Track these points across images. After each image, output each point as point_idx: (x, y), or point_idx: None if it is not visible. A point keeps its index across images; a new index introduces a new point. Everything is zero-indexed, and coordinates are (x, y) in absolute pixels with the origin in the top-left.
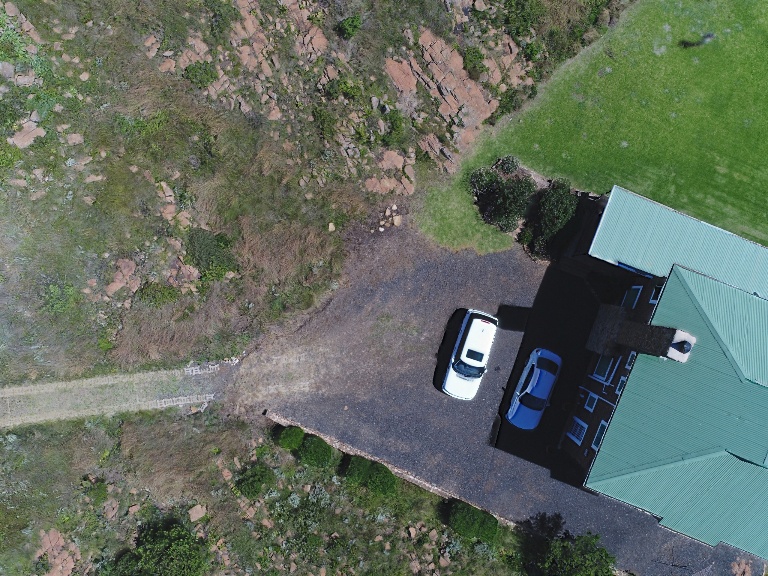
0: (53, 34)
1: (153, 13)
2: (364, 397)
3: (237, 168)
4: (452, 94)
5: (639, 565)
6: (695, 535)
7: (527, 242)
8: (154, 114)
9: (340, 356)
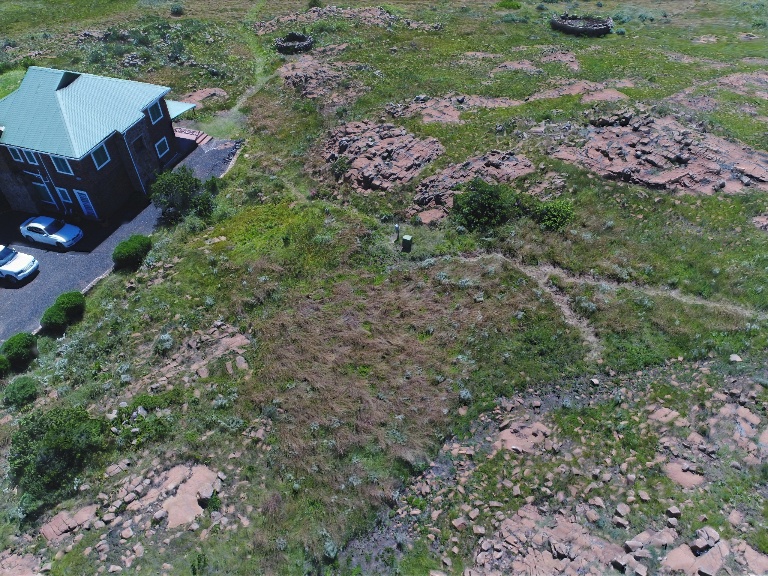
0: None
1: None
2: (1, 330)
3: None
4: None
5: None
6: (133, 120)
7: None
8: None
9: None
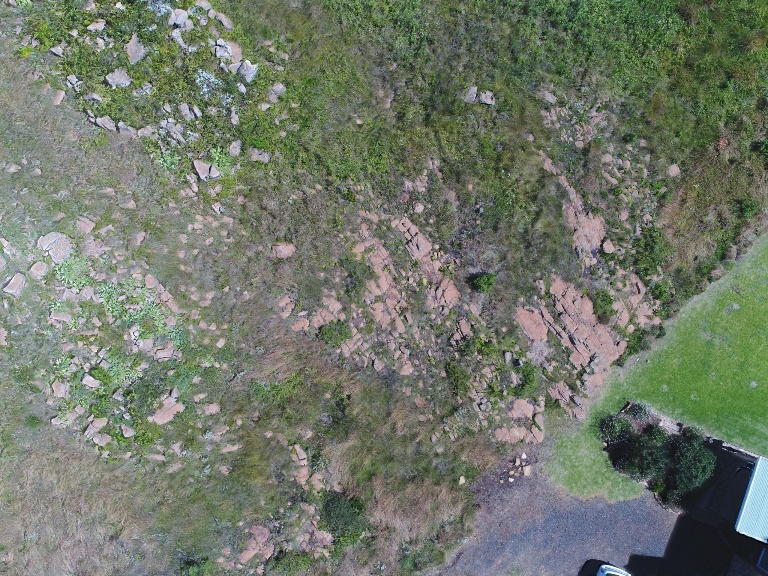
0: (191, 303)
1: (290, 277)
2: None
3: (370, 427)
4: (584, 344)
5: None
6: None
7: (659, 492)
8: (289, 377)
9: None
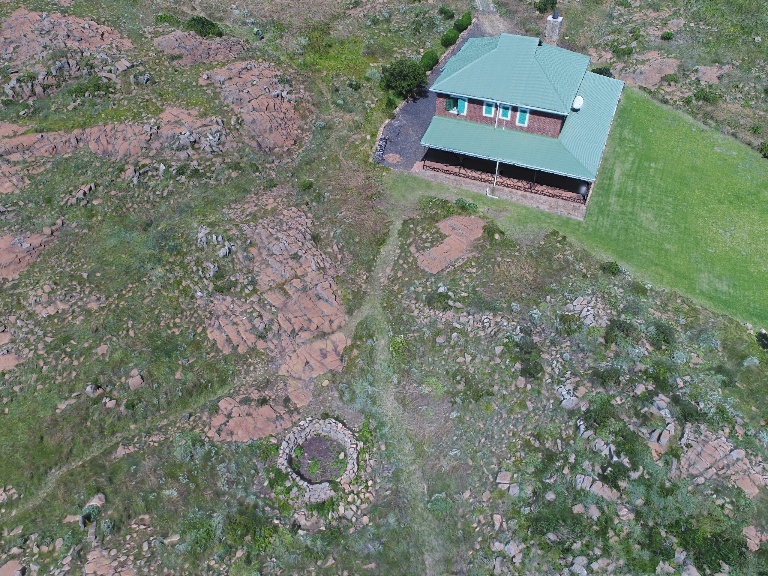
0: None
1: None
2: None
3: None
4: None
5: None
6: None
7: None
8: None
9: None
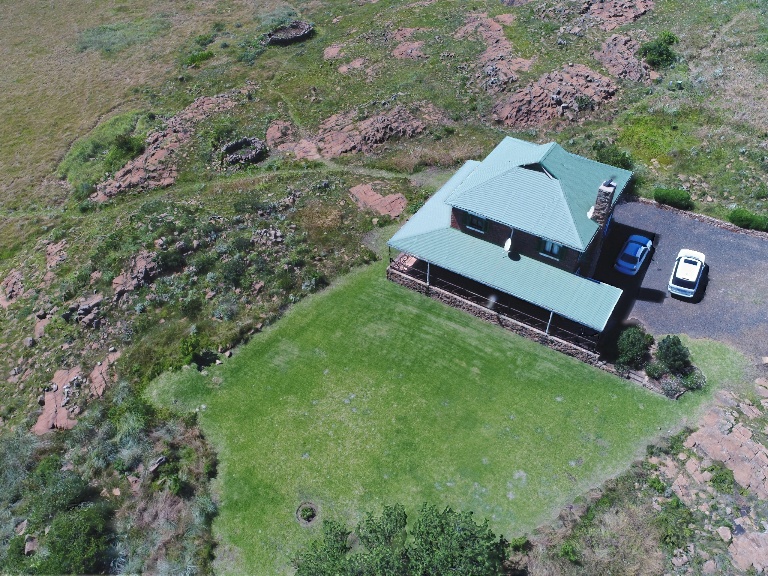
0: None
1: None
2: (761, 262)
3: None
4: None
5: None
6: None
7: None
8: None
9: None
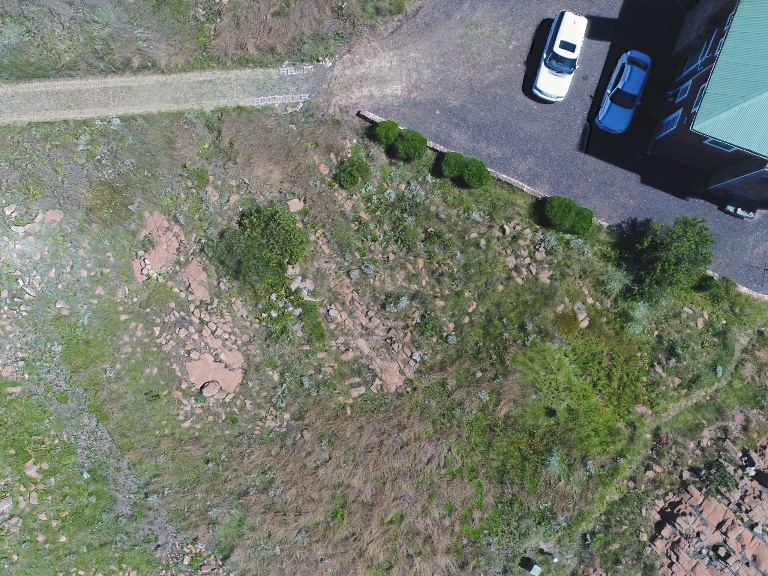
0: None
1: None
2: (455, 102)
3: None
4: None
5: (731, 269)
6: None
7: None
8: None
9: (431, 61)
